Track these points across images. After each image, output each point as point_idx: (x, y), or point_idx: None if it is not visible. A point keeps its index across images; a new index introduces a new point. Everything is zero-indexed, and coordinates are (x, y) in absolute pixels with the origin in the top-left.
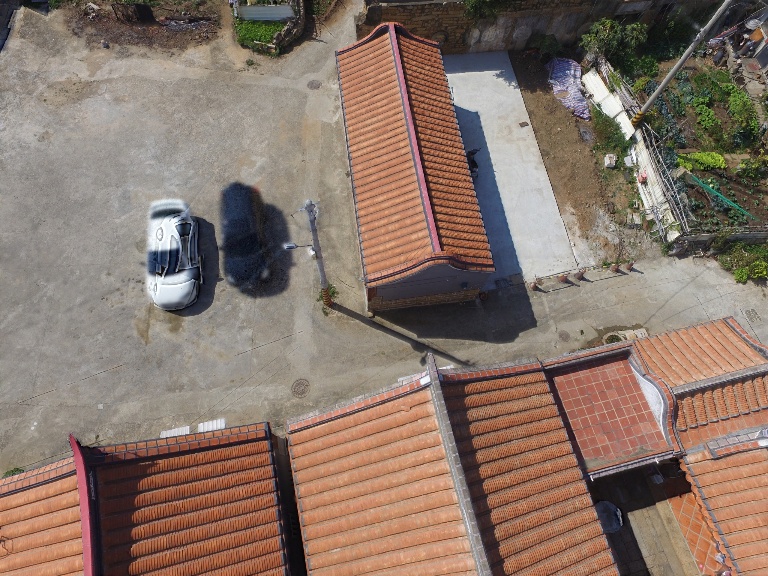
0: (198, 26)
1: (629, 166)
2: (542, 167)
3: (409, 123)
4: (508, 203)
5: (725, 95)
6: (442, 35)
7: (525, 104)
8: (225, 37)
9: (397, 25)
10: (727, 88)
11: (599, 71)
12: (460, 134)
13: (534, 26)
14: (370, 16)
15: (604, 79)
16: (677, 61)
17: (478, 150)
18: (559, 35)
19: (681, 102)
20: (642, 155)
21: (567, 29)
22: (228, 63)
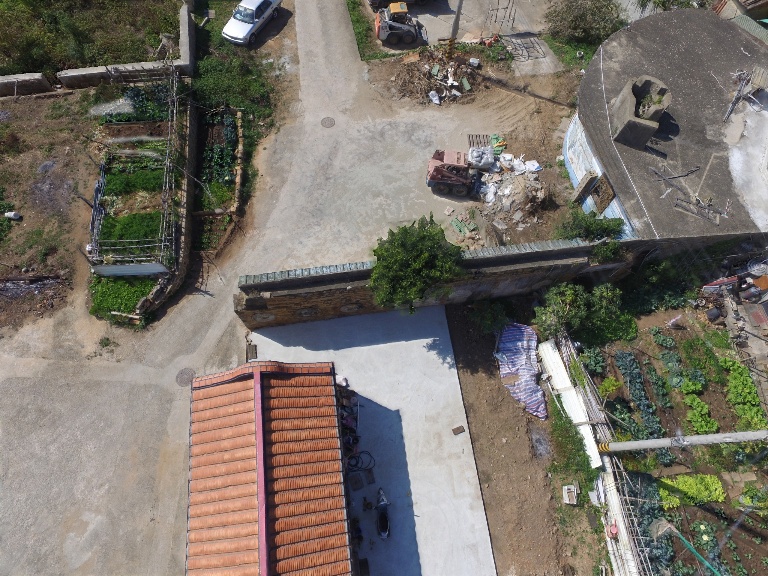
0: (42, 288)
1: (595, 505)
2: (479, 505)
3: (260, 571)
4: (430, 573)
5: (723, 370)
6: (354, 305)
7: (462, 393)
8: (76, 303)
9: (265, 371)
10: (725, 364)
11: (559, 347)
12: (347, 542)
13: (474, 289)
14: (251, 304)
15: (564, 364)
16: (661, 314)
17: (388, 504)
18: (509, 290)
19: (666, 382)
20: (612, 496)
21: (518, 286)
22: (74, 346)
